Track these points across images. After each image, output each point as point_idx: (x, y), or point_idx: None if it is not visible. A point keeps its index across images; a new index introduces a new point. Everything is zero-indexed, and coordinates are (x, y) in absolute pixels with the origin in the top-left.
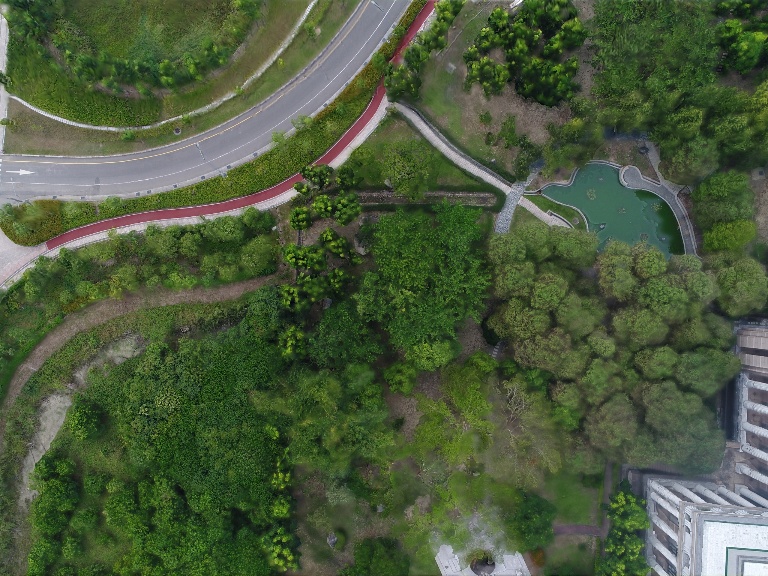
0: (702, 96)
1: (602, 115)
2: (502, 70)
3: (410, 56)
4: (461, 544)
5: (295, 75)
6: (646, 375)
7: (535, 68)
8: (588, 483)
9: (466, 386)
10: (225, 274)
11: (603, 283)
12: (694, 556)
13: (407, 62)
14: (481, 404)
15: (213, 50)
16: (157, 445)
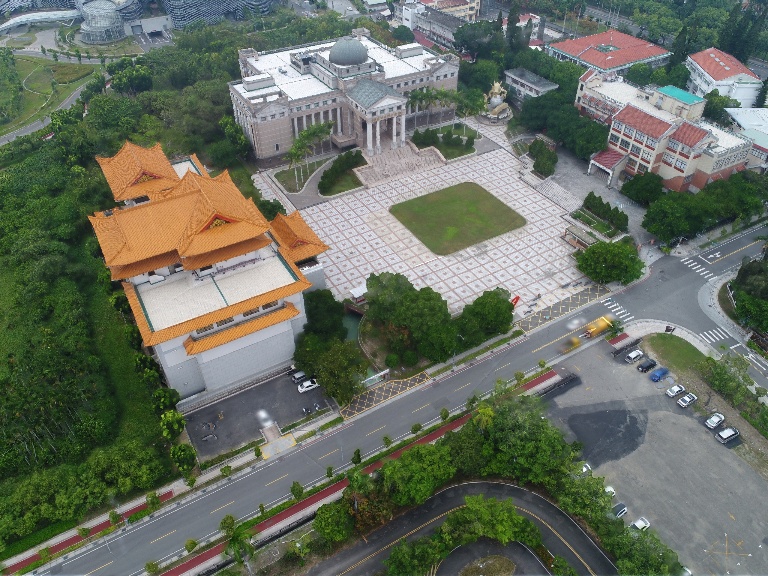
0: (193, 60)
1: (165, 75)
2: (124, 78)
3: (88, 86)
4: (164, 149)
5: (43, 116)
6: (208, 96)
7: (136, 75)
8: (217, 140)
9: (144, 119)
10: (25, 147)
11: (186, 96)
12: (234, 92)
13: (88, 88)
14: (151, 118)
15: (2, 108)
16: (2, 185)
